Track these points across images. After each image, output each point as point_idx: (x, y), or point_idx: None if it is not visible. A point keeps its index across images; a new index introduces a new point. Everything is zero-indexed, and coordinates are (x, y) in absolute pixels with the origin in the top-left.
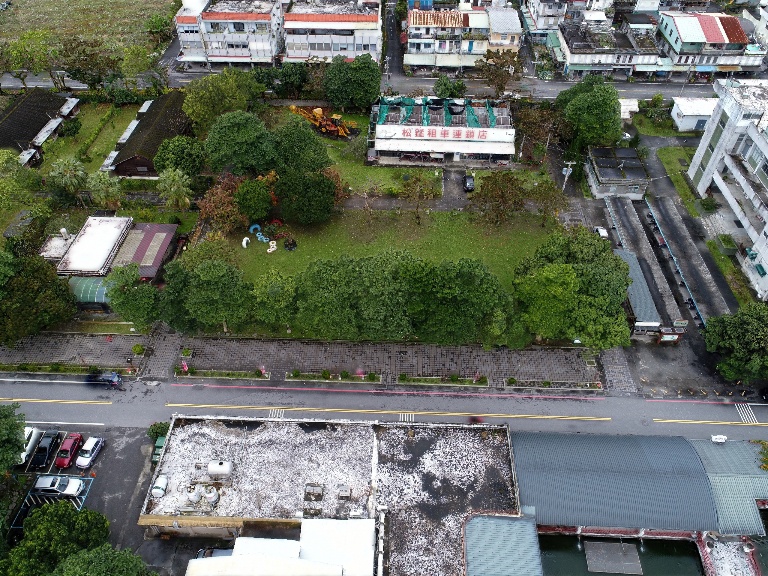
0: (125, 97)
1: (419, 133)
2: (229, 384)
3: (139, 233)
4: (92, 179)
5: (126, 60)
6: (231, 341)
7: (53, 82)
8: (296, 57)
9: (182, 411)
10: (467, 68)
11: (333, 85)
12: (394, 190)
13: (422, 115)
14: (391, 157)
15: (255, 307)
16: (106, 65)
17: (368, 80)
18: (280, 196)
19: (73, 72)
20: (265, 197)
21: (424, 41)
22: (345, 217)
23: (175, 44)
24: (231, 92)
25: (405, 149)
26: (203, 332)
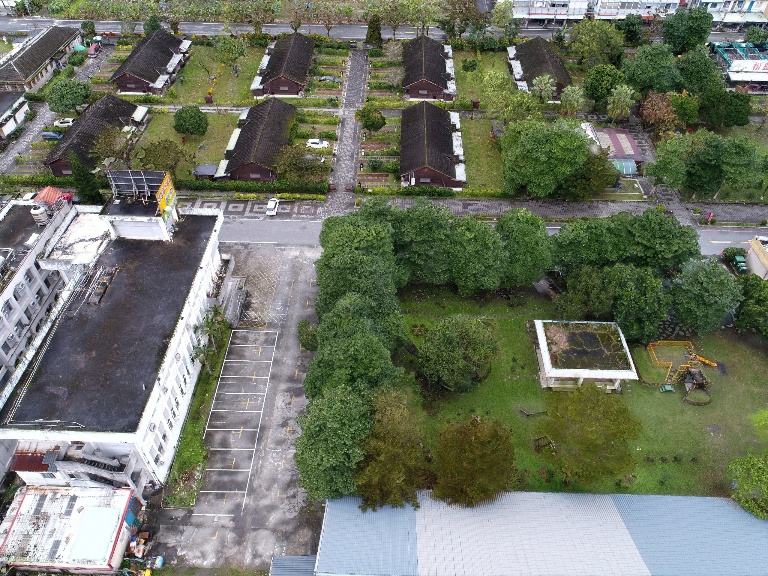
0: (494, 43)
1: (767, 67)
2: (744, 230)
3: (603, 134)
4: (568, 91)
5: (497, 12)
6: (721, 205)
7: (417, 33)
8: (605, 15)
9: (726, 245)
10: (745, 24)
11: (676, 31)
12: (763, 109)
13: (759, 54)
14: (734, 88)
15: (763, 173)
16: (480, 16)
17: (706, 27)
18: (706, 106)
19: (446, 23)
20: (696, 107)
21: (715, 1)
22: (735, 128)
23: (479, 7)
24: (613, 34)
25: (756, 79)
26: (697, 199)
